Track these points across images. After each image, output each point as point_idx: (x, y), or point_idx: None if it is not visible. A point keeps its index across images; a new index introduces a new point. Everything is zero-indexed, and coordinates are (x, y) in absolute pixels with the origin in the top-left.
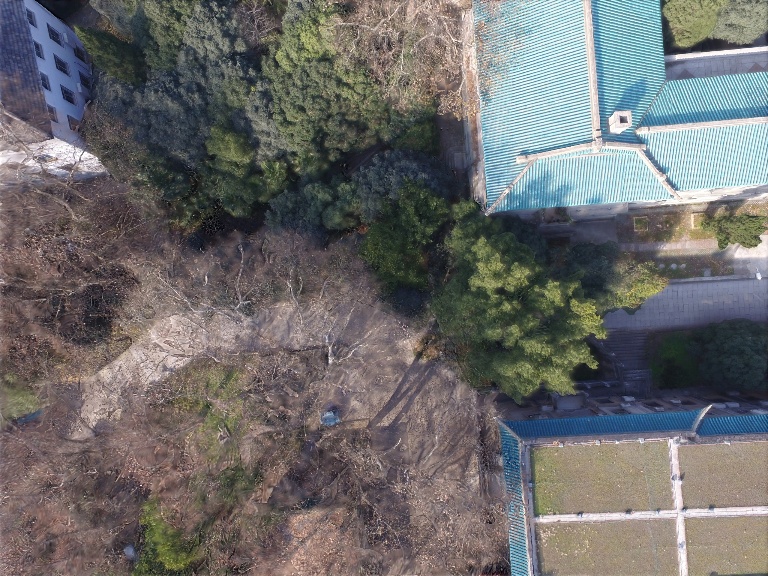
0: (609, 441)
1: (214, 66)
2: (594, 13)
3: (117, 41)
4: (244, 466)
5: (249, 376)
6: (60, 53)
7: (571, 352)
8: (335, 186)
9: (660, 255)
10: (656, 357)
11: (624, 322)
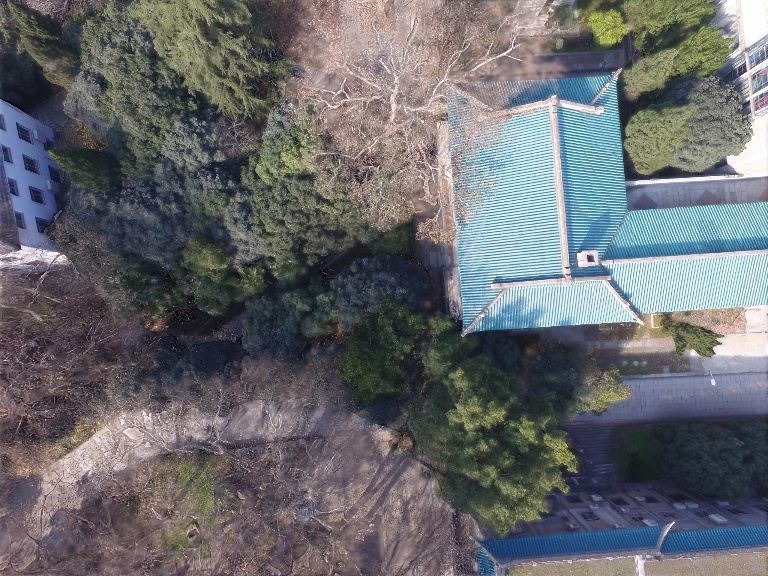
0: None
1: (193, 178)
2: (562, 155)
3: (93, 156)
4: (214, 564)
5: (221, 469)
6: (29, 151)
7: (544, 481)
8: (313, 292)
9: (623, 352)
10: (621, 452)
11: (591, 415)
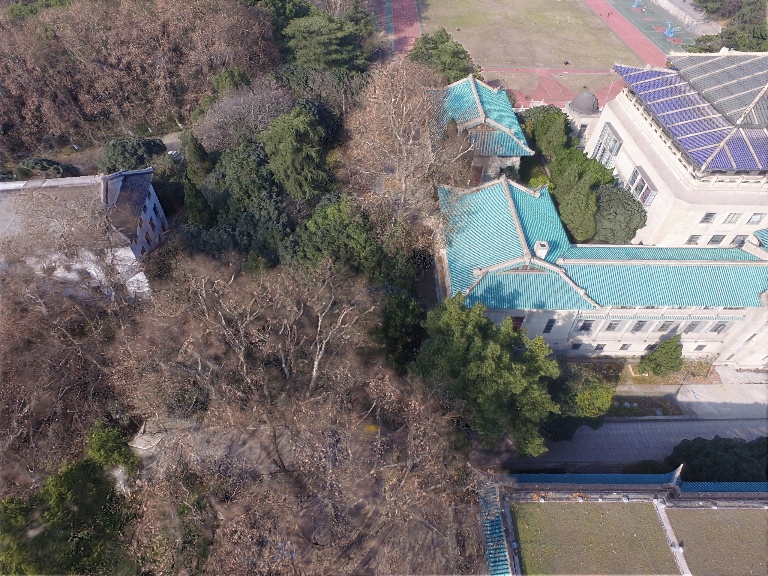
0: (591, 499)
1: (263, 224)
2: (514, 203)
3: (205, 199)
4: None
5: None
6: (154, 219)
7: (532, 386)
8: None
9: None
10: None
11: (596, 456)
